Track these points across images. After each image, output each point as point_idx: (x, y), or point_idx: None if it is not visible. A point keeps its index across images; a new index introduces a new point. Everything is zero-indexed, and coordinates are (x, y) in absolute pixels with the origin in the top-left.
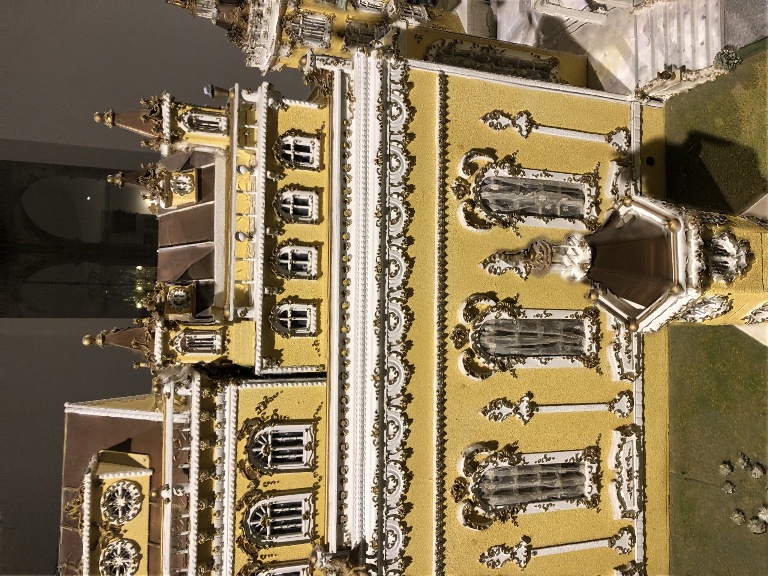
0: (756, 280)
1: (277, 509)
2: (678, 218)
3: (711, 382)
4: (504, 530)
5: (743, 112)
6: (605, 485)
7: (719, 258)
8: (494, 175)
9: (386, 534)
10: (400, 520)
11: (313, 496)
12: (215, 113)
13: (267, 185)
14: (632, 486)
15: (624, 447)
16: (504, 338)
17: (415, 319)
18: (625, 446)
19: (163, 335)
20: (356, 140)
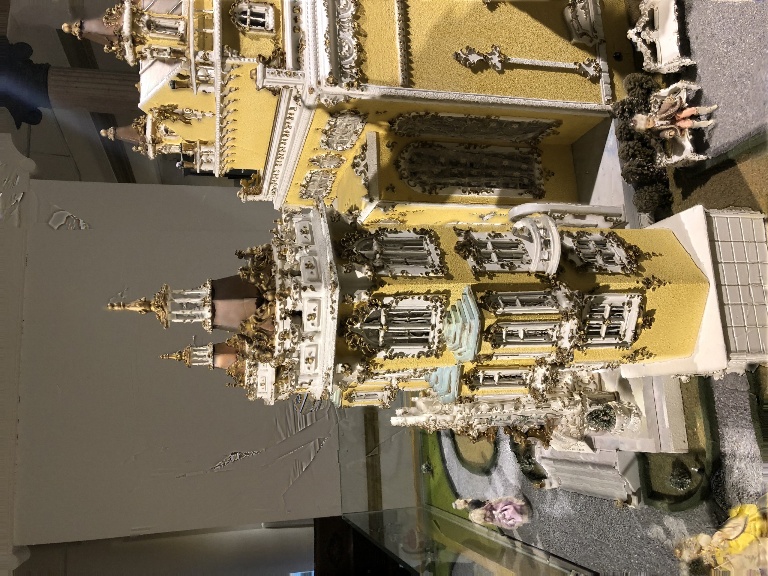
0: None
1: None
2: None
3: None
4: None
5: None
6: None
7: None
8: None
9: None
10: None
11: None
12: None
13: None
14: None
15: None
16: None
17: None
18: None
19: None
20: None
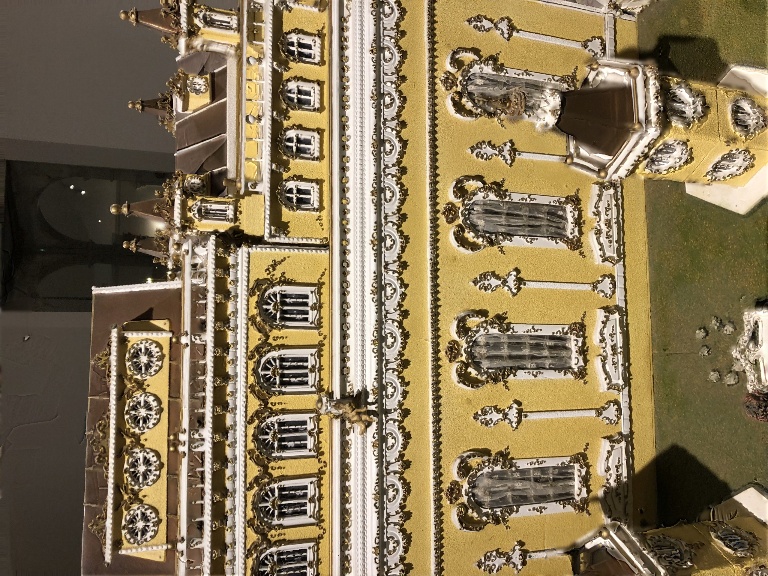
0: (712, 131)
1: (286, 363)
2: (636, 66)
3: (686, 259)
4: (496, 393)
5: (704, 8)
6: (591, 359)
7: (677, 109)
8: (479, 72)
9: (386, 385)
10: (398, 374)
11: (318, 352)
12: (227, 13)
13: (274, 75)
14: (616, 361)
15: (608, 324)
16: (492, 218)
17: (409, 195)
18: (609, 323)
19: (182, 202)
20: (353, 34)
